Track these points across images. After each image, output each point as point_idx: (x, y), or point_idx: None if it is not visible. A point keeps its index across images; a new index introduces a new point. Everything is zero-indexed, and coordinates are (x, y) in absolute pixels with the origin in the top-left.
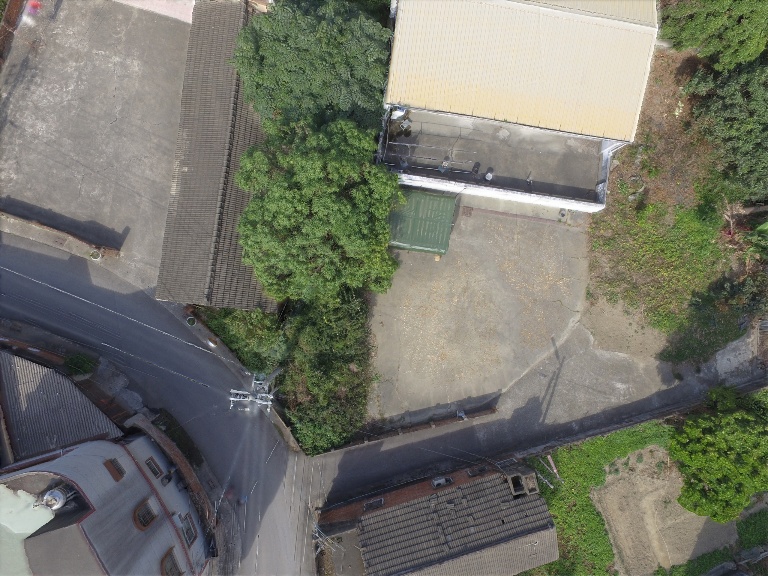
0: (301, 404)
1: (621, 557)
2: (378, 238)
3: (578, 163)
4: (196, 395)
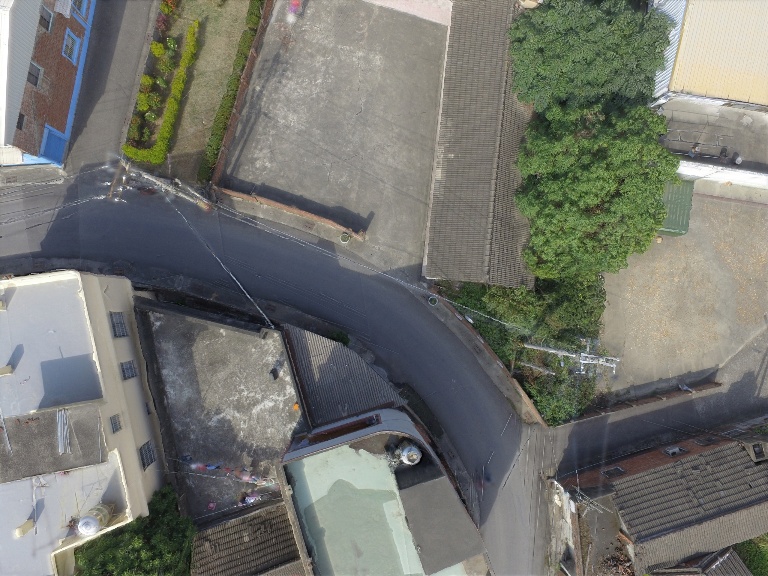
0: (538, 378)
1: None
2: (656, 218)
3: None
4: (436, 370)
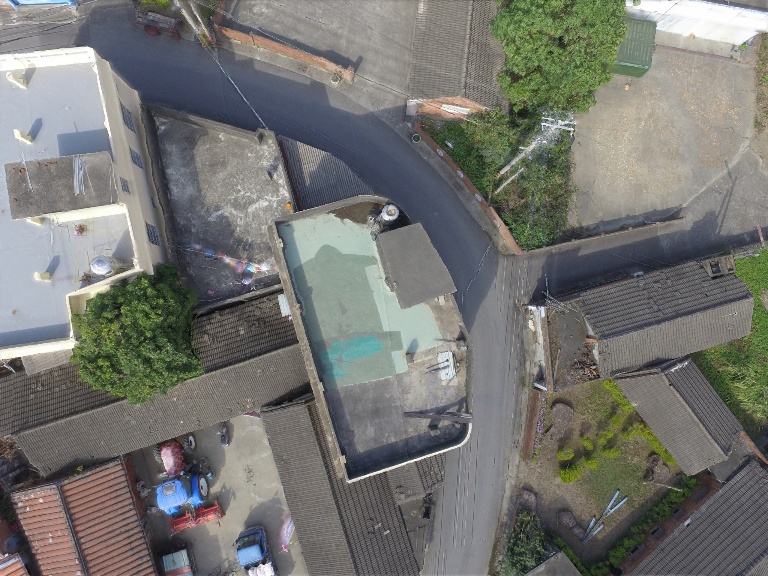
0: (513, 210)
1: None
2: (617, 33)
3: None
4: (419, 204)
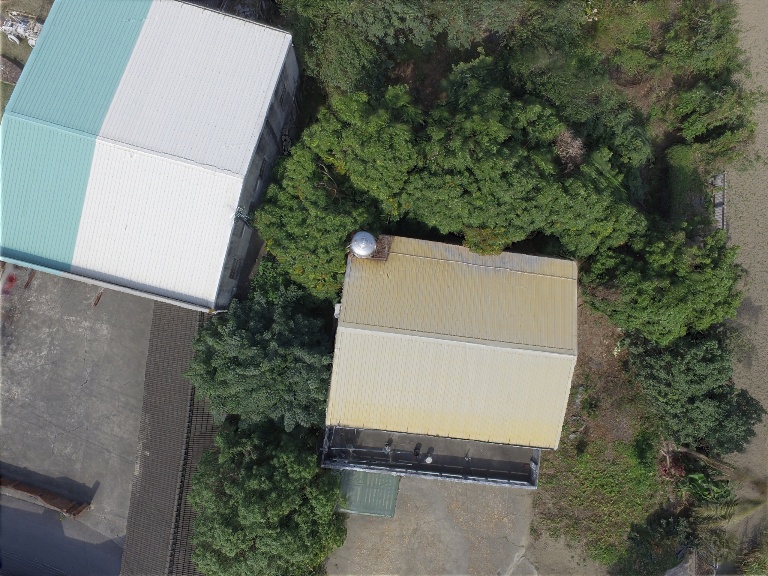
0: None
1: None
2: (322, 541)
3: None
4: None
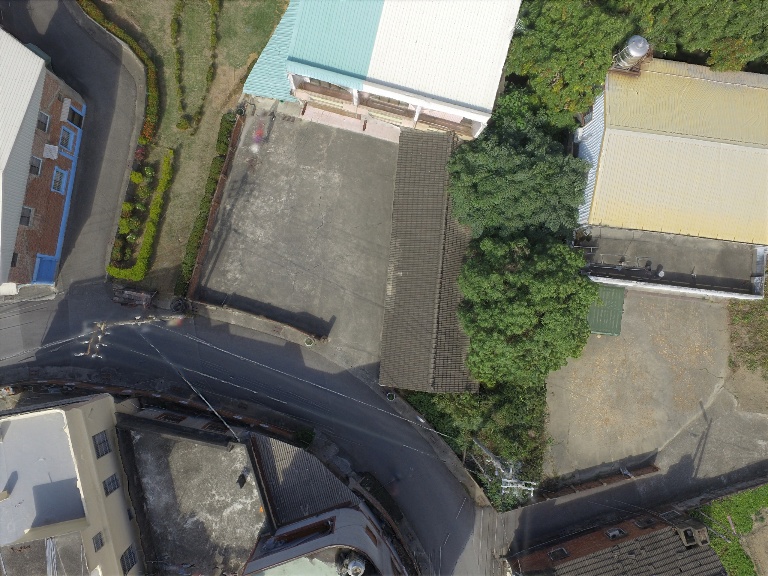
0: (488, 466)
1: None
2: (581, 335)
3: (734, 258)
4: (395, 460)
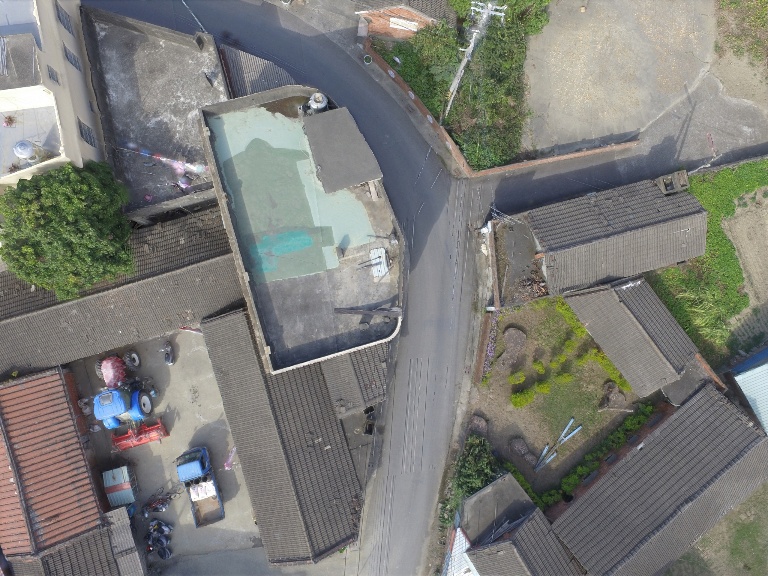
0: (465, 131)
1: (750, 280)
2: None
3: None
4: (370, 126)
